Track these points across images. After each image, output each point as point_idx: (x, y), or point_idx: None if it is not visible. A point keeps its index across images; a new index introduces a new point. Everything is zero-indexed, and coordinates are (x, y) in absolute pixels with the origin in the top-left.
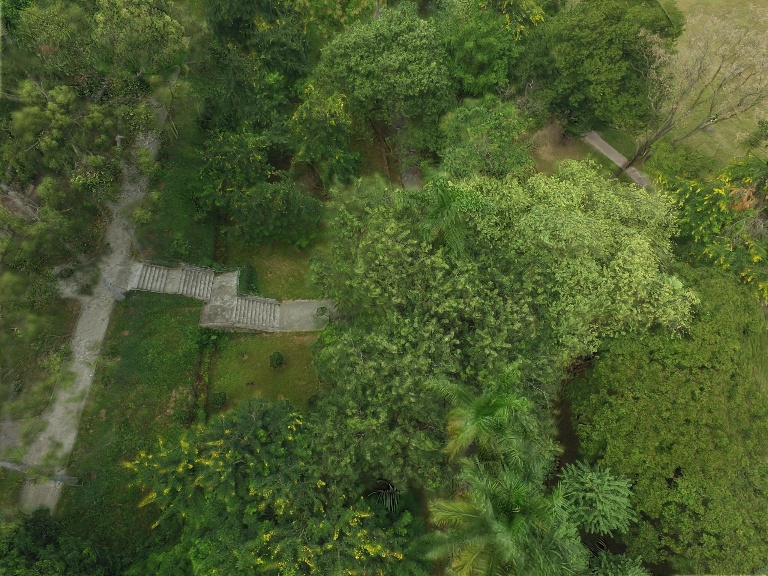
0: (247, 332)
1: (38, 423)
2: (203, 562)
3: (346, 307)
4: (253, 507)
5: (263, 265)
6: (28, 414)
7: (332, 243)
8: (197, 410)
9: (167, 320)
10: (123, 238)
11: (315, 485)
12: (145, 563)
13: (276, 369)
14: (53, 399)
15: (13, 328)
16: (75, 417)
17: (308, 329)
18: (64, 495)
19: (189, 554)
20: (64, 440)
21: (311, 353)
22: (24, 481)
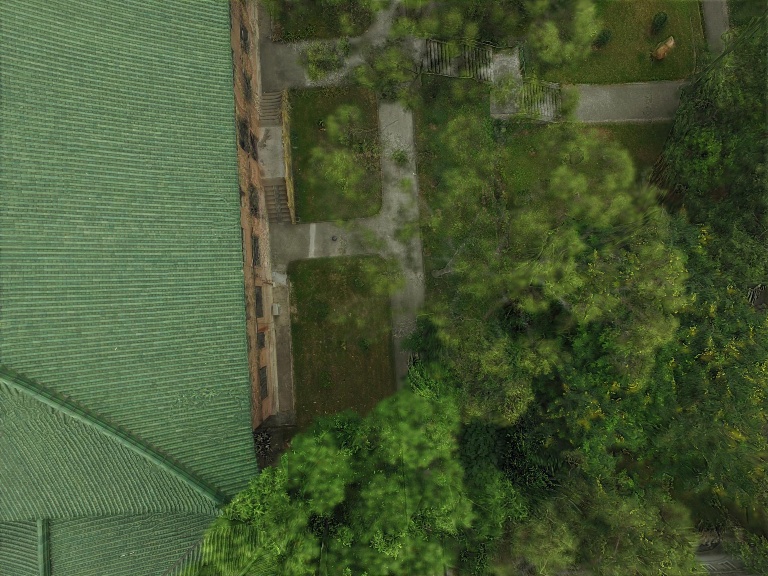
0: (531, 123)
1: (379, 221)
2: (631, 345)
3: (732, 106)
4: (658, 303)
5: (535, 37)
6: (366, 213)
7: (613, 6)
8: (499, 206)
9: (464, 111)
10: (392, 1)
11: (725, 288)
12: (521, 339)
13: (569, 165)
14: (384, 198)
15: (320, 121)
16: (413, 216)
17: (594, 120)
18: (430, 285)
19: (601, 337)
20: (410, 237)
21: (602, 148)
22: (388, 273)
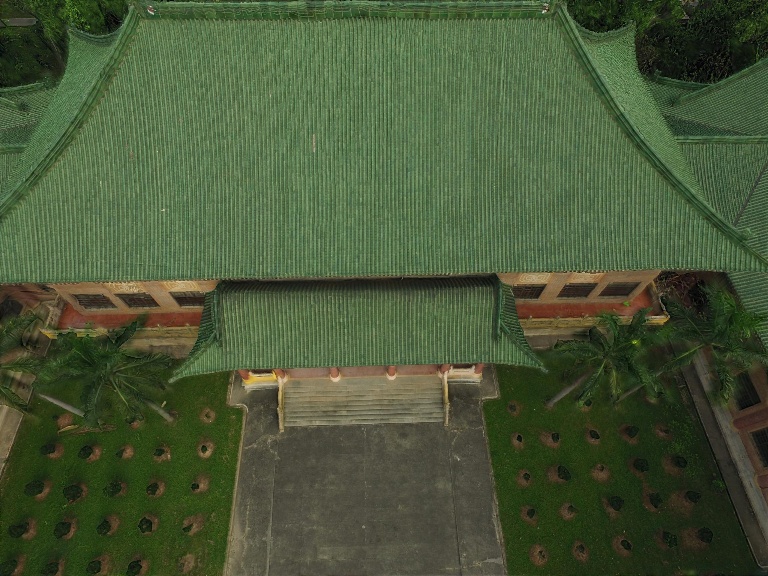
0: None
1: None
2: None
3: None
4: None
5: None
6: None
7: None
8: None
9: None
10: None
11: None
12: None
13: None
14: None
15: None
16: None
17: None
18: None
19: None
20: None
21: None
22: None
